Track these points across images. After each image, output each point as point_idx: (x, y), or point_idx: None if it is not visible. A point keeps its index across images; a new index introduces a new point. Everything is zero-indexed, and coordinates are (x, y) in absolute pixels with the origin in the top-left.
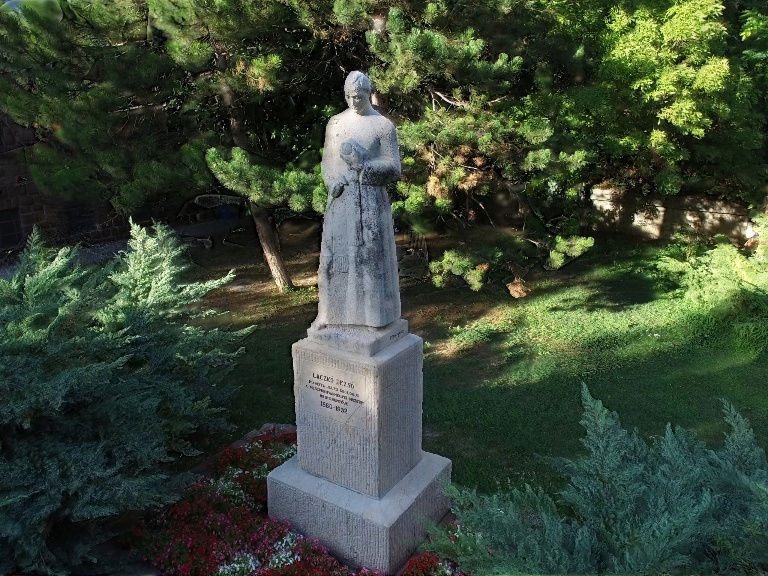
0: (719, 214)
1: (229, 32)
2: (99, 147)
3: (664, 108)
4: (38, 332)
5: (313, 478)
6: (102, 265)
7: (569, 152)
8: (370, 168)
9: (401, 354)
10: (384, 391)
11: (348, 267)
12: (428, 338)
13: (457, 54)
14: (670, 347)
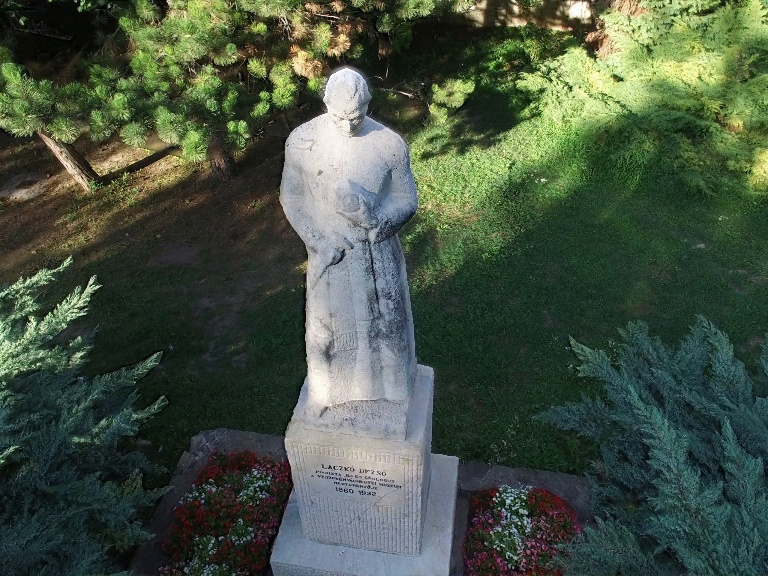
0: None
1: None
2: None
3: None
4: None
5: (329, 548)
6: None
7: None
8: (387, 222)
9: (428, 411)
10: None
11: (356, 343)
12: None
13: None
14: (557, 191)
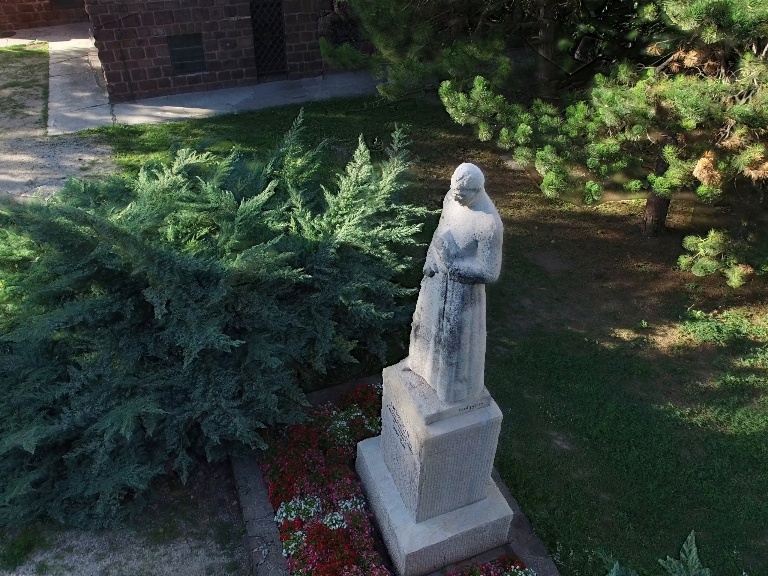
0: None
1: None
2: (379, 28)
3: None
4: (228, 262)
5: (385, 468)
6: (344, 161)
7: None
8: (457, 270)
9: (463, 429)
10: (432, 456)
11: (430, 338)
12: (655, 312)
13: None
14: None
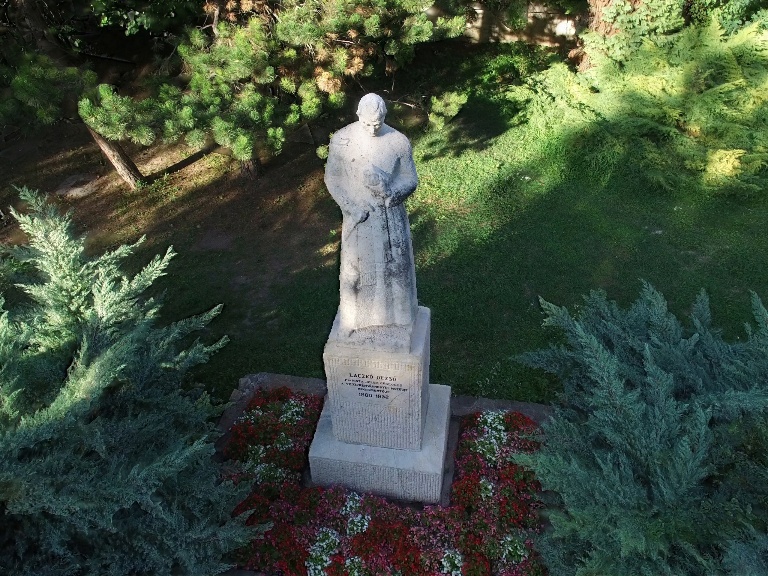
0: (532, 13)
1: None
2: None
3: None
4: (37, 415)
5: (353, 446)
6: None
7: (438, 8)
8: (397, 193)
9: (426, 336)
10: (422, 375)
11: (375, 280)
12: (326, 222)
13: None
14: (539, 187)
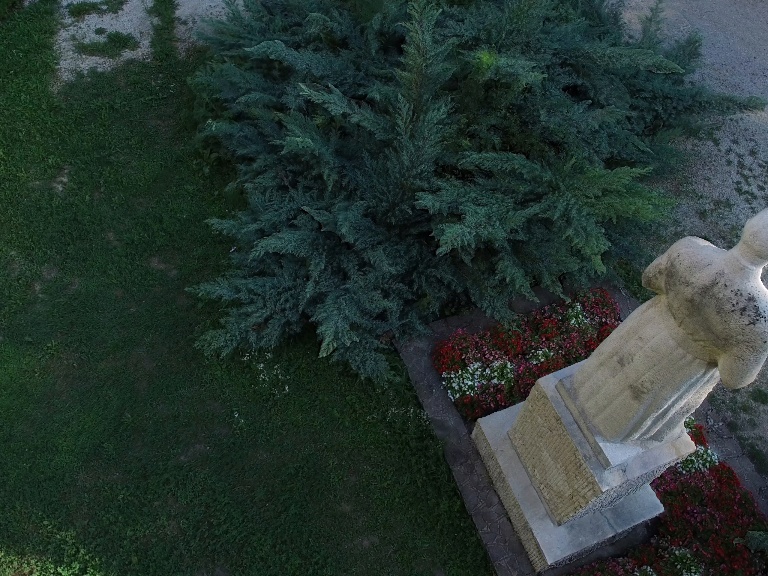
0: None
1: None
2: None
3: None
4: None
5: None
6: None
7: None
8: None
9: None
10: None
11: None
12: None
13: None
14: None
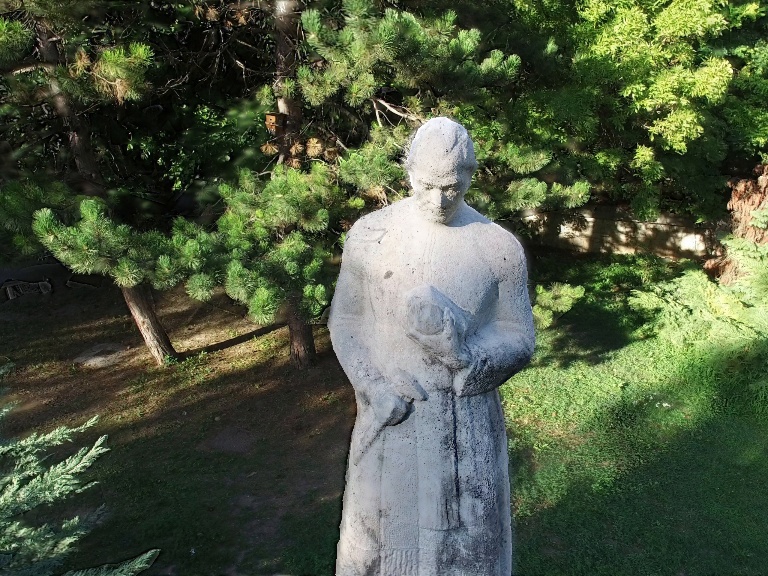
0: (652, 224)
1: (59, 4)
2: None
3: (657, 120)
4: None
5: None
6: None
7: (552, 179)
8: (485, 361)
9: None
10: None
11: (416, 569)
12: None
13: (439, 50)
14: (684, 420)
